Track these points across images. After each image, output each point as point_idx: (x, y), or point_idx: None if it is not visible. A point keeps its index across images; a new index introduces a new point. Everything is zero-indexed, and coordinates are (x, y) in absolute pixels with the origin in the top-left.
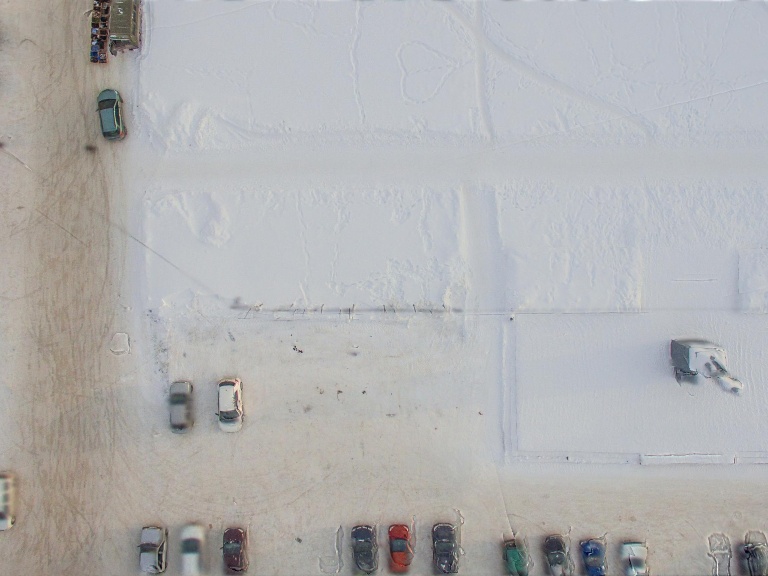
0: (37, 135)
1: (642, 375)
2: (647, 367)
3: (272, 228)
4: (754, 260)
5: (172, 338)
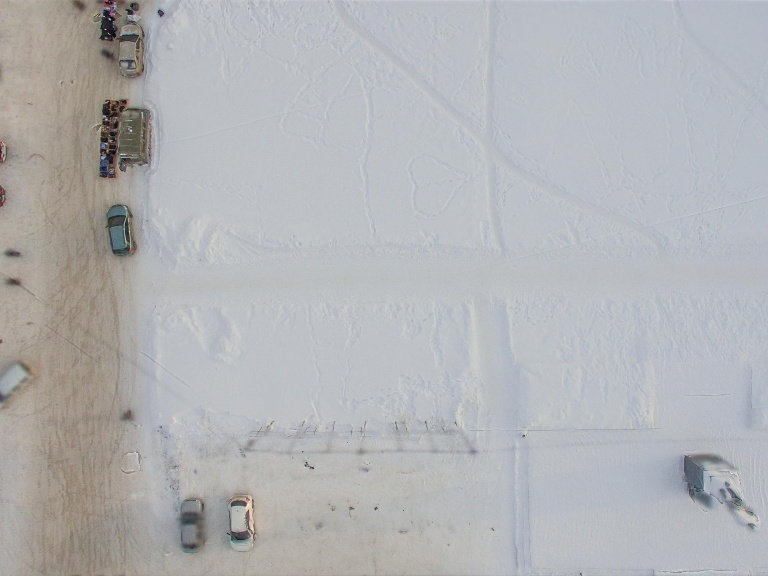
0: (46, 250)
1: (655, 491)
2: (660, 483)
3: (283, 344)
4: (767, 375)
5: (183, 455)
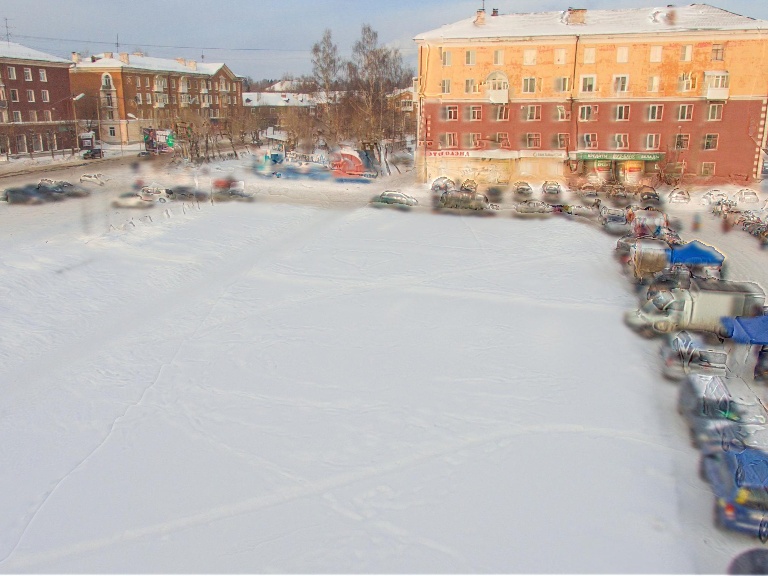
0: None
1: None
2: None
3: None
4: None
5: None
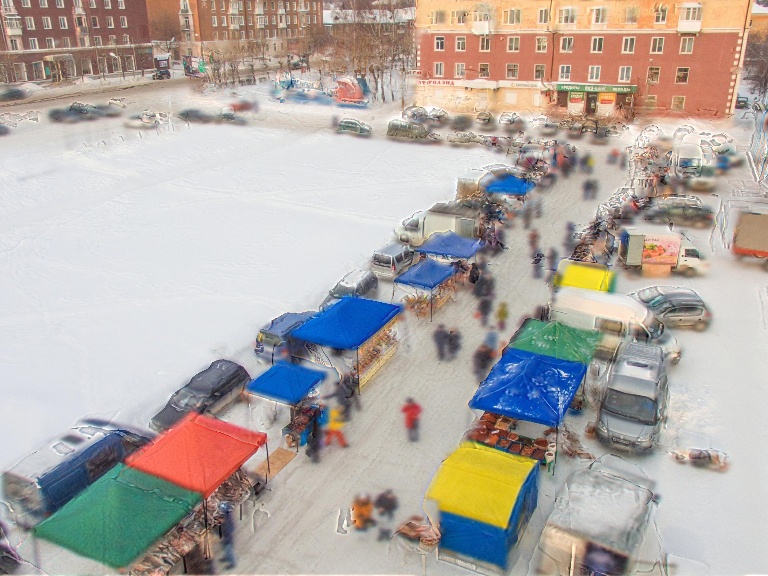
0: None
1: None
2: None
3: None
4: None
5: None
